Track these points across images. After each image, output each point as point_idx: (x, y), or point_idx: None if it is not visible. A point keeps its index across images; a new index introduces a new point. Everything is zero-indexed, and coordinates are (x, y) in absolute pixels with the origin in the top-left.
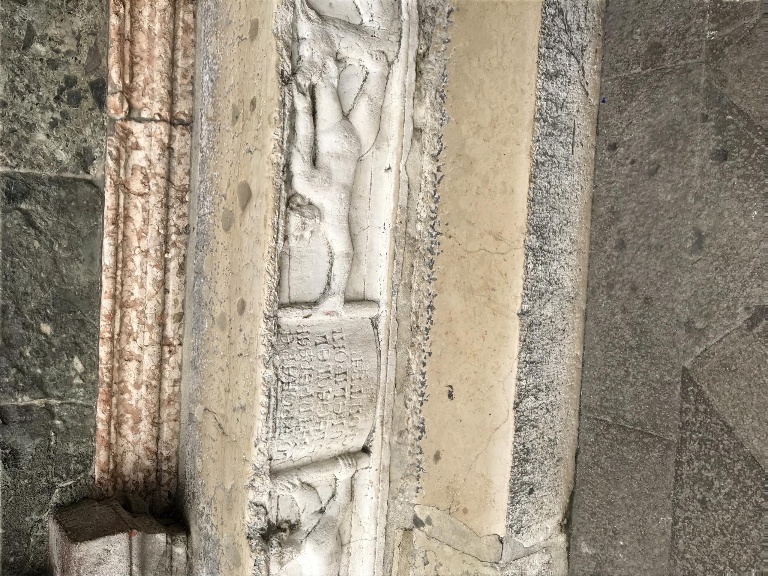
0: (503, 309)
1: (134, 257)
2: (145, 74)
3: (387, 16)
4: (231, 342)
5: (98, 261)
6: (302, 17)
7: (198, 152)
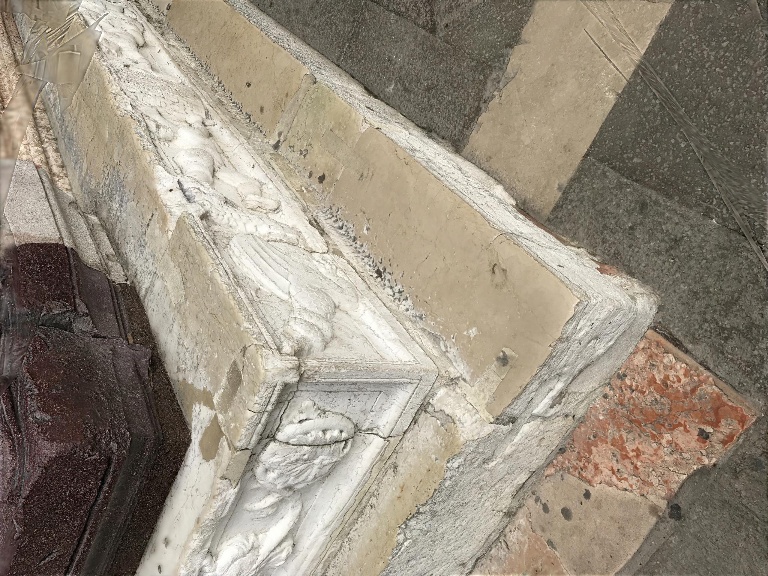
0: (243, 31)
1: None
2: None
3: None
4: None
5: None
6: None
7: (51, 110)
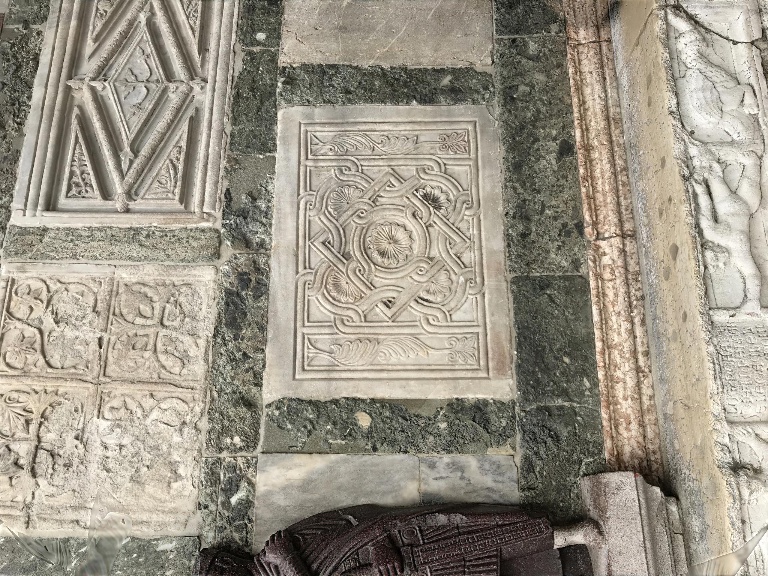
0: None
1: (612, 318)
2: (604, 214)
3: (749, 131)
4: (682, 344)
5: (591, 320)
6: (691, 146)
7: (642, 248)
